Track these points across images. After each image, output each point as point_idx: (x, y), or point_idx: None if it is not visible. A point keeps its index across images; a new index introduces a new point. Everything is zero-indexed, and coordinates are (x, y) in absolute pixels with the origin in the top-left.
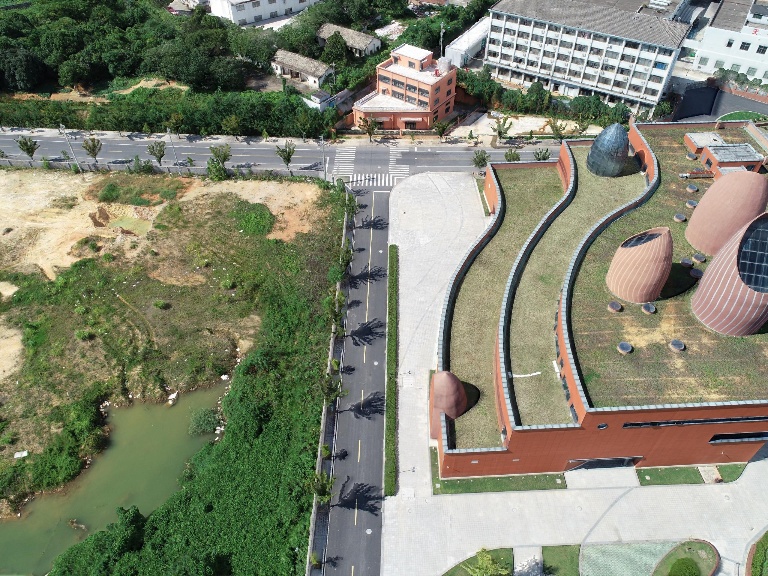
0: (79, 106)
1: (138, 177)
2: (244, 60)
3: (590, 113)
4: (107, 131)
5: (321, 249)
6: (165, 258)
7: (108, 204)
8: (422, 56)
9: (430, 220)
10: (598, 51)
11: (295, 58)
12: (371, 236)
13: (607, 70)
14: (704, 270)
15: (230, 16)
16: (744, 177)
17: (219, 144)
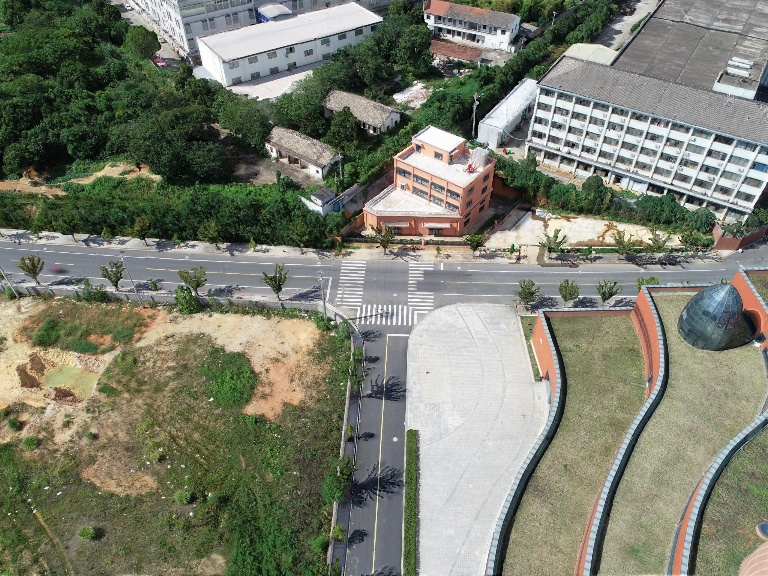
0: (28, 199)
1: (88, 306)
2: (234, 134)
3: (663, 218)
4: (59, 233)
5: (315, 436)
6: (106, 444)
7: (44, 350)
8: (452, 145)
9: (461, 386)
10: (676, 143)
11: (294, 139)
12: (382, 412)
13: (687, 166)
14: None
15: (222, 74)
16: None
17: (195, 254)
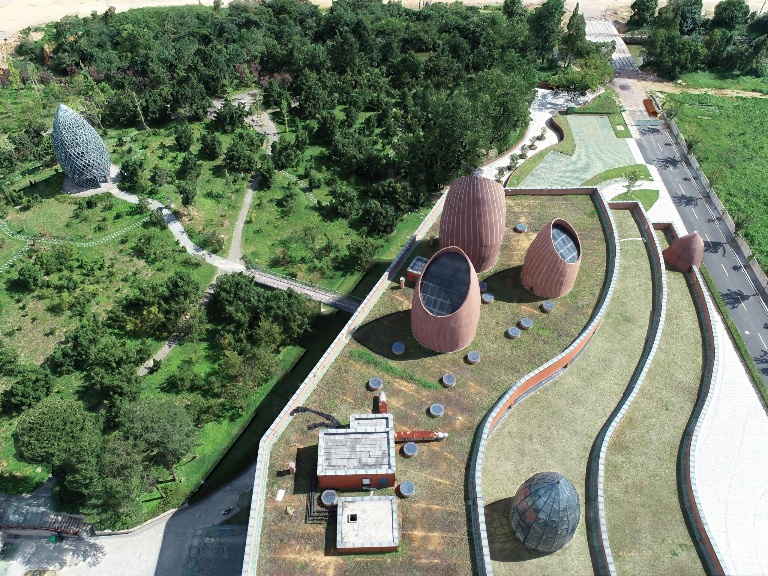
0: None
1: None
2: None
3: None
4: None
5: None
6: None
7: None
8: None
9: None
10: None
11: None
12: None
13: None
14: None
15: None
16: None
17: None
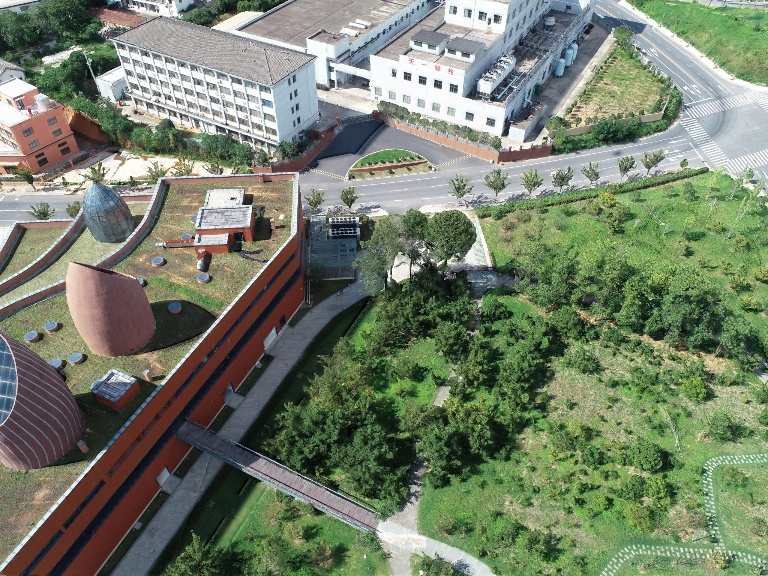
0: None
1: None
2: None
3: (217, 154)
4: None
5: None
6: None
7: None
8: (22, 92)
9: None
10: (214, 86)
11: None
12: None
13: (229, 107)
14: (70, 374)
15: None
16: (70, 269)
17: None
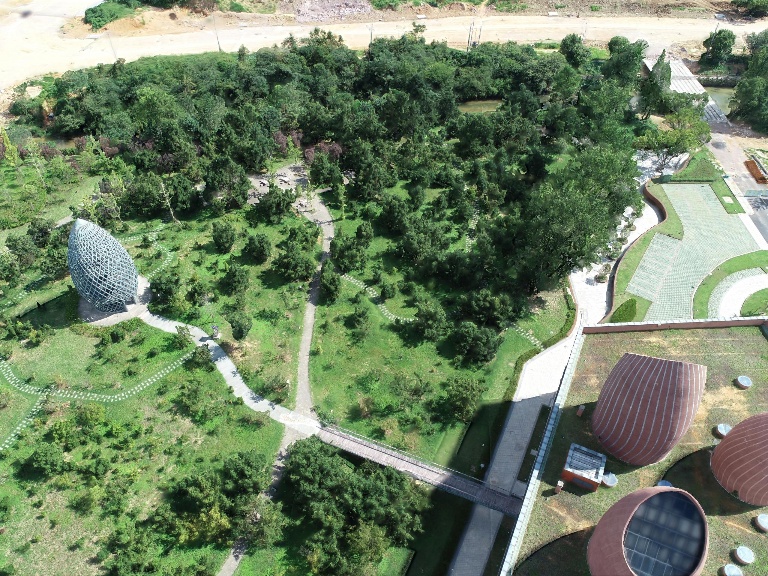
0: None
1: None
2: None
3: None
4: None
5: None
6: None
7: None
8: None
9: None
10: None
11: None
12: None
13: None
14: None
15: None
16: None
17: None
